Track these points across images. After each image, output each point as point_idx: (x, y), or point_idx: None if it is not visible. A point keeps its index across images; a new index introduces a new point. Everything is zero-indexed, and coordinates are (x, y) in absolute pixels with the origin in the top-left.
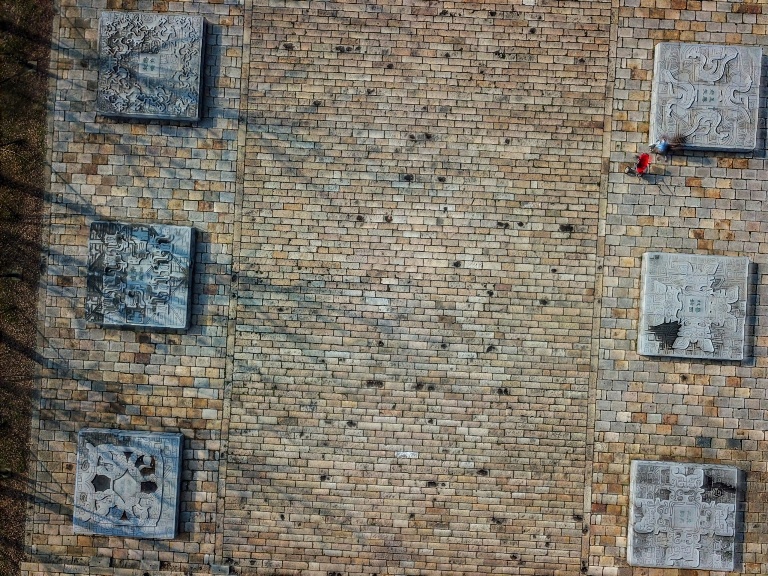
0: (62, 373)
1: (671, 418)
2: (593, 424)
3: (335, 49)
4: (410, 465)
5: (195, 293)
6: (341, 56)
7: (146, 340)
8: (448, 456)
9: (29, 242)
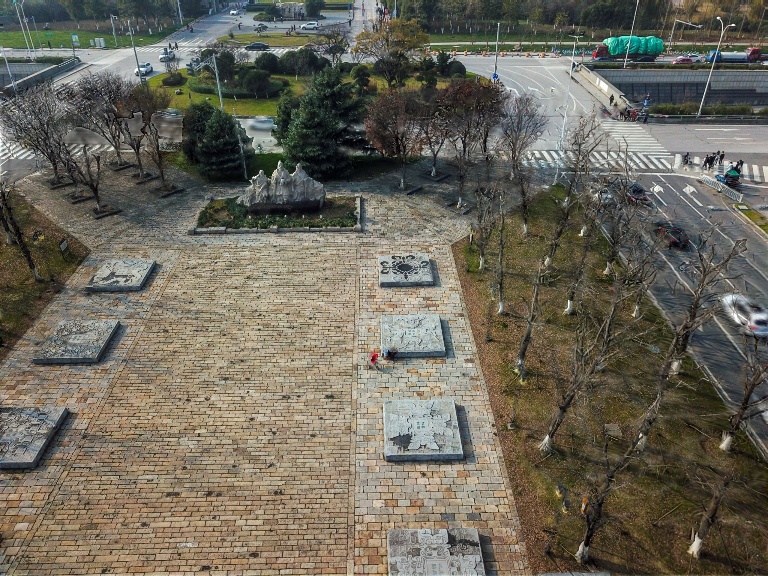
0: None
1: (418, 502)
2: (353, 510)
3: (193, 331)
4: (189, 553)
5: (50, 446)
6: (196, 333)
7: None
8: (225, 543)
9: None
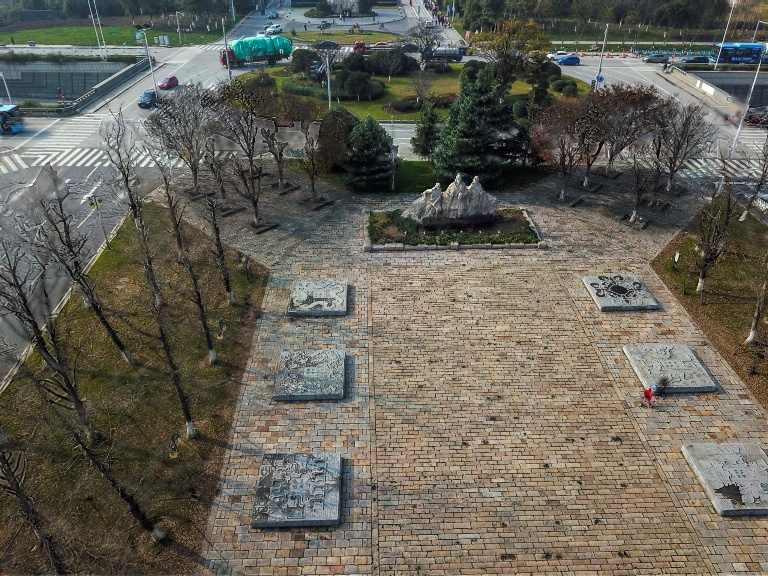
0: (221, 571)
1: None
2: (717, 575)
3: (427, 362)
4: None
5: (343, 499)
6: (432, 365)
7: (301, 538)
8: None
9: (210, 475)
